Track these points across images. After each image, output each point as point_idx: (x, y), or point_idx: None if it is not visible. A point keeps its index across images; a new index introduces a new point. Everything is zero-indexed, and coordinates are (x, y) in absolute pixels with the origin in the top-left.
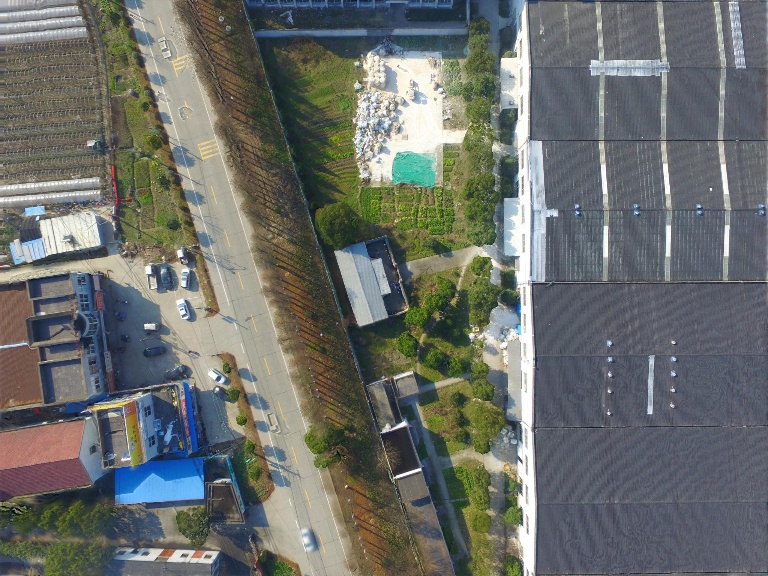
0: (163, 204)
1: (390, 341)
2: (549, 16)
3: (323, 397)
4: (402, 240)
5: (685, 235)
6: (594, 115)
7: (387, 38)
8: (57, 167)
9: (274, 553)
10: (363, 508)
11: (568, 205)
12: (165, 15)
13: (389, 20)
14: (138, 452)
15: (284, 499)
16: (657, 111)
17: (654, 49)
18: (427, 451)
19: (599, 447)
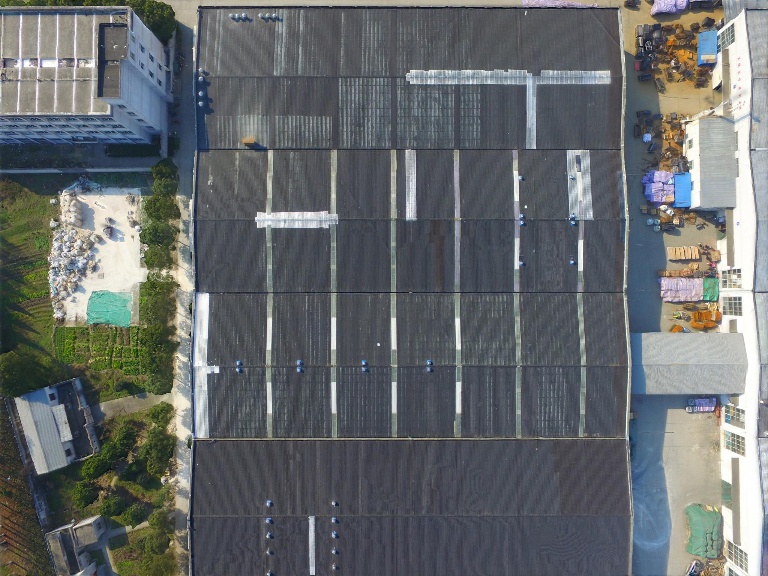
0: None
1: None
2: (219, 165)
3: (9, 542)
4: (95, 381)
5: (351, 392)
6: (262, 267)
7: (84, 175)
8: None
9: None
10: None
11: (230, 361)
12: None
13: (88, 156)
14: None
15: None
16: (327, 263)
17: (324, 200)
18: None
19: None
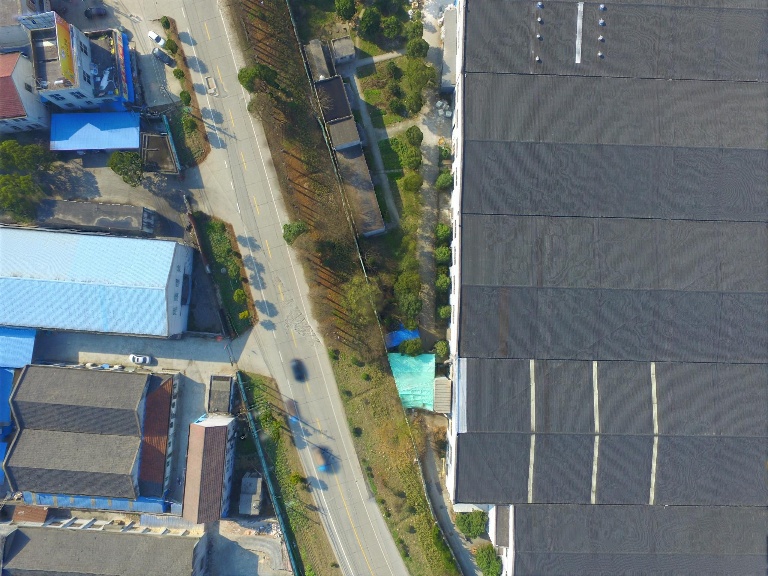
0: None
1: (330, 15)
2: None
3: (262, 63)
4: None
5: None
6: None
7: None
8: None
9: (209, 214)
10: (298, 172)
11: None
12: None
13: None
14: (69, 67)
15: (220, 160)
16: None
17: None
18: (363, 123)
19: (527, 91)
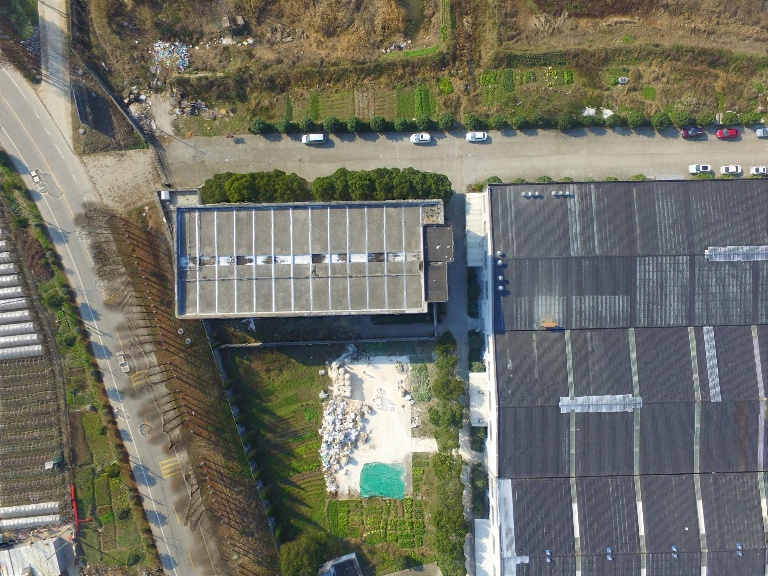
0: (125, 523)
1: None
2: (517, 348)
3: None
4: (371, 555)
5: None
6: (565, 452)
7: (352, 345)
8: (14, 492)
9: None
10: None
11: (539, 551)
12: (122, 330)
13: (354, 324)
14: None
15: None
16: (630, 446)
17: (626, 382)
18: None
19: None
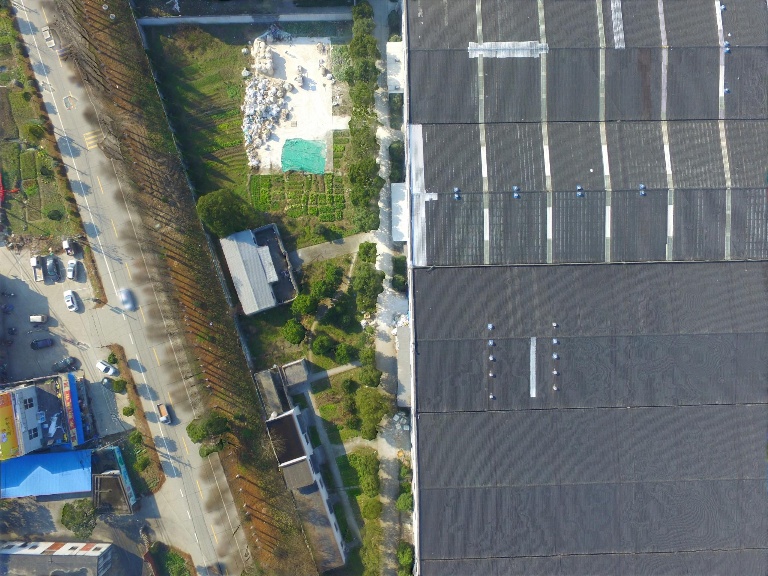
0: (50, 195)
1: (281, 329)
2: None
3: (213, 387)
4: (292, 227)
5: (566, 217)
6: (474, 98)
7: (274, 24)
8: None
9: (166, 544)
10: (255, 497)
11: (447, 188)
12: (47, 4)
13: (277, 6)
14: (12, 444)
15: (175, 490)
16: (537, 93)
17: (533, 30)
18: (320, 439)
19: (482, 431)
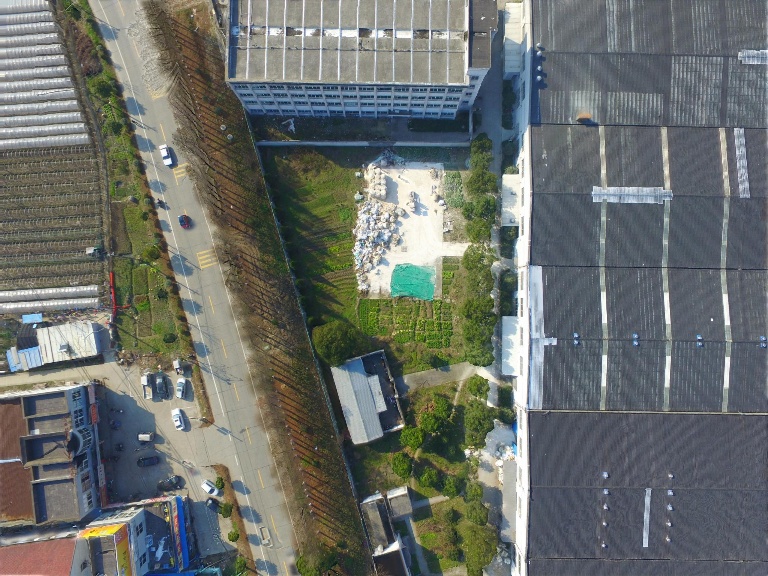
0: (160, 312)
1: (385, 455)
2: (552, 140)
3: (316, 511)
4: (399, 353)
5: (685, 366)
6: (595, 241)
7: (389, 149)
8: (55, 274)
9: None
10: None
11: (567, 334)
12: (167, 123)
13: (391, 130)
14: None
15: None
16: (659, 238)
17: (657, 176)
18: (420, 567)
19: None
